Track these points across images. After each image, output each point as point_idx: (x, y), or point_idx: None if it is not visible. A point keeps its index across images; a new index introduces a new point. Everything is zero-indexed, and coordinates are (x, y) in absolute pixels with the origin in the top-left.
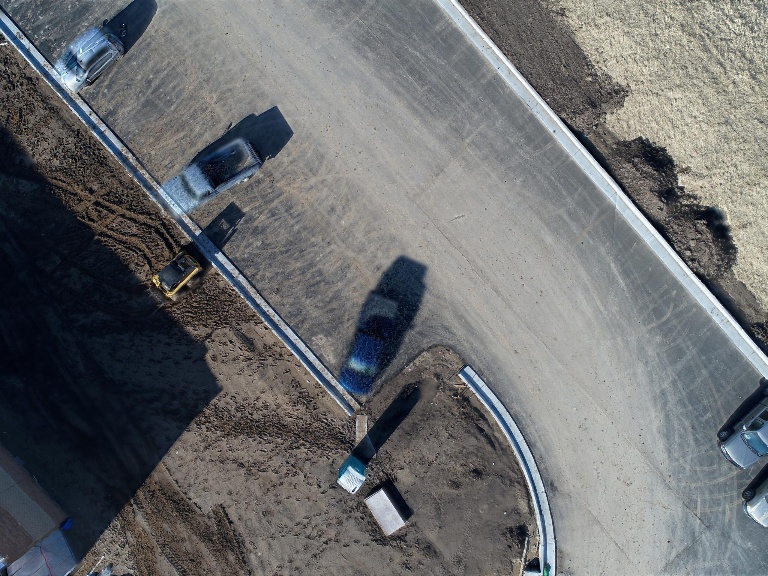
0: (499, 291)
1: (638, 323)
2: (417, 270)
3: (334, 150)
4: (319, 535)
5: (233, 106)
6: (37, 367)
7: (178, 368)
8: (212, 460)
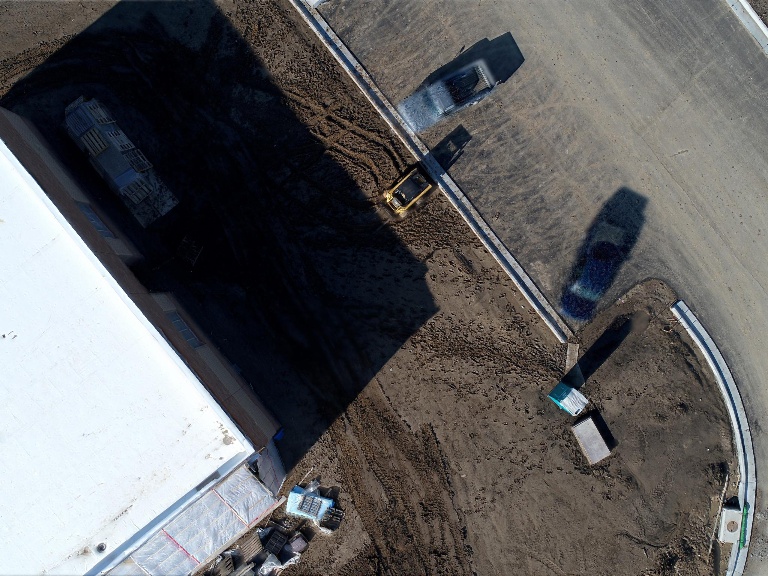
0: (717, 228)
1: None
2: (637, 202)
3: (563, 79)
4: (524, 460)
5: (467, 30)
6: (261, 276)
7: (398, 285)
8: (425, 379)
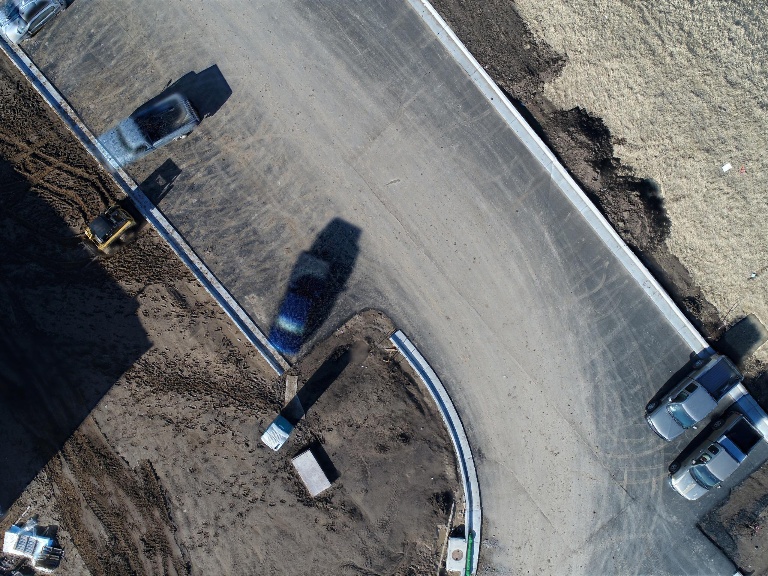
0: (432, 256)
1: (570, 293)
2: (351, 233)
3: (272, 110)
4: (246, 494)
5: (173, 63)
6: None
7: (109, 322)
8: (141, 415)
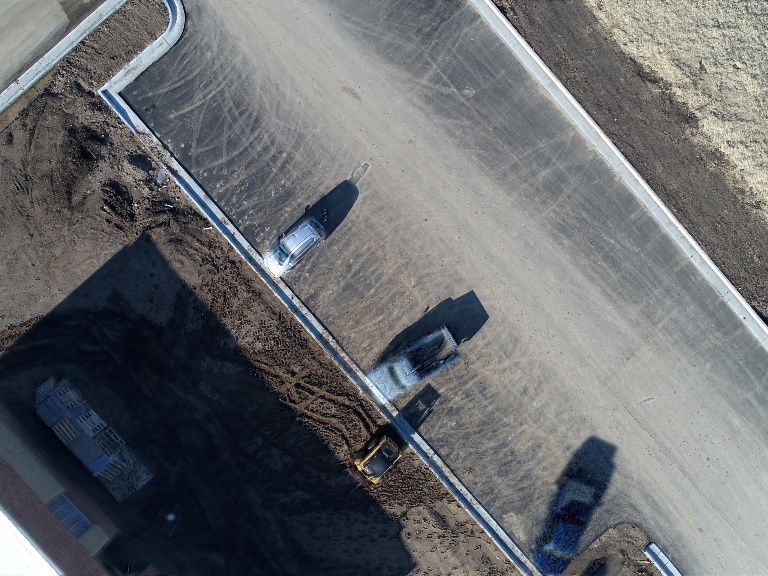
0: (686, 471)
1: None
2: (606, 450)
3: (528, 333)
4: None
5: (430, 290)
6: (238, 544)
7: (374, 545)
8: None
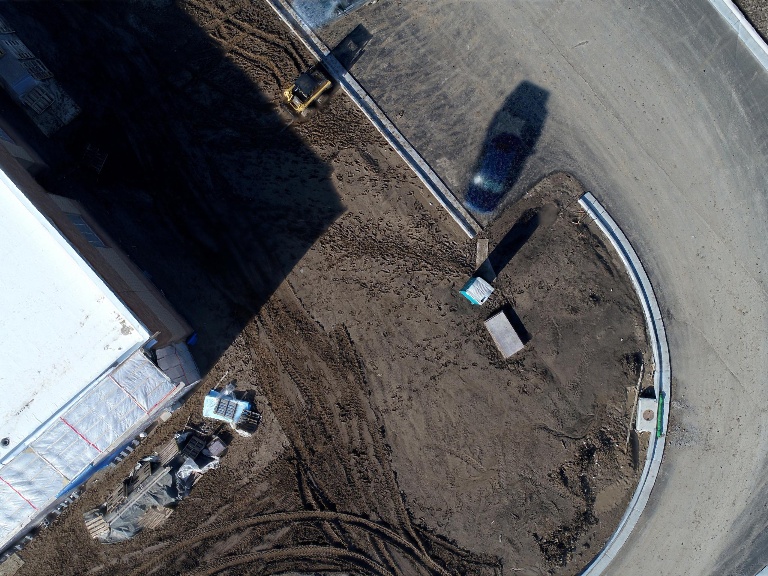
0: (621, 118)
1: (757, 152)
2: (540, 95)
3: None
4: (438, 357)
5: None
6: (167, 182)
7: (305, 186)
8: (336, 279)
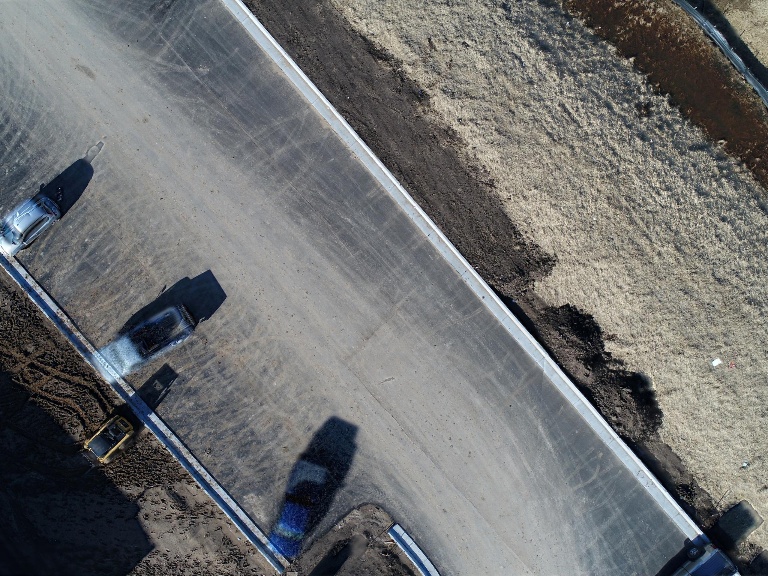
0: (428, 452)
1: (565, 484)
2: (347, 430)
3: (266, 313)
4: None
5: (167, 269)
6: None
7: (110, 526)
8: None
